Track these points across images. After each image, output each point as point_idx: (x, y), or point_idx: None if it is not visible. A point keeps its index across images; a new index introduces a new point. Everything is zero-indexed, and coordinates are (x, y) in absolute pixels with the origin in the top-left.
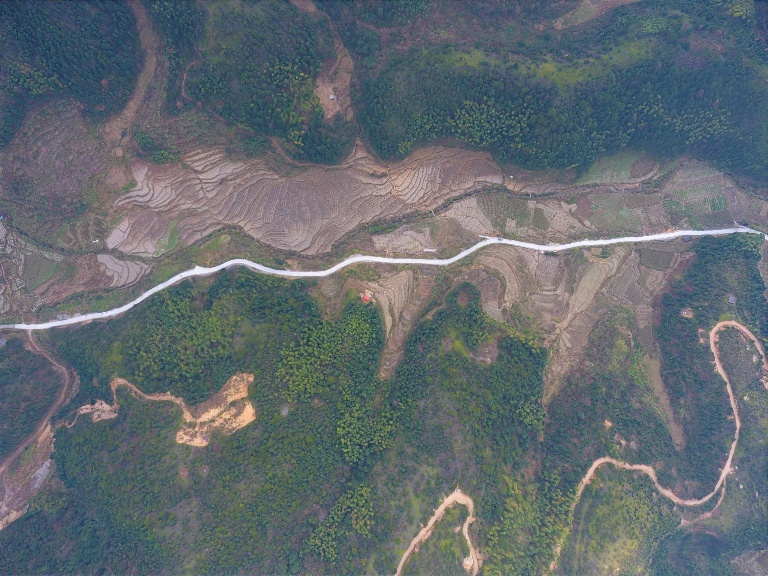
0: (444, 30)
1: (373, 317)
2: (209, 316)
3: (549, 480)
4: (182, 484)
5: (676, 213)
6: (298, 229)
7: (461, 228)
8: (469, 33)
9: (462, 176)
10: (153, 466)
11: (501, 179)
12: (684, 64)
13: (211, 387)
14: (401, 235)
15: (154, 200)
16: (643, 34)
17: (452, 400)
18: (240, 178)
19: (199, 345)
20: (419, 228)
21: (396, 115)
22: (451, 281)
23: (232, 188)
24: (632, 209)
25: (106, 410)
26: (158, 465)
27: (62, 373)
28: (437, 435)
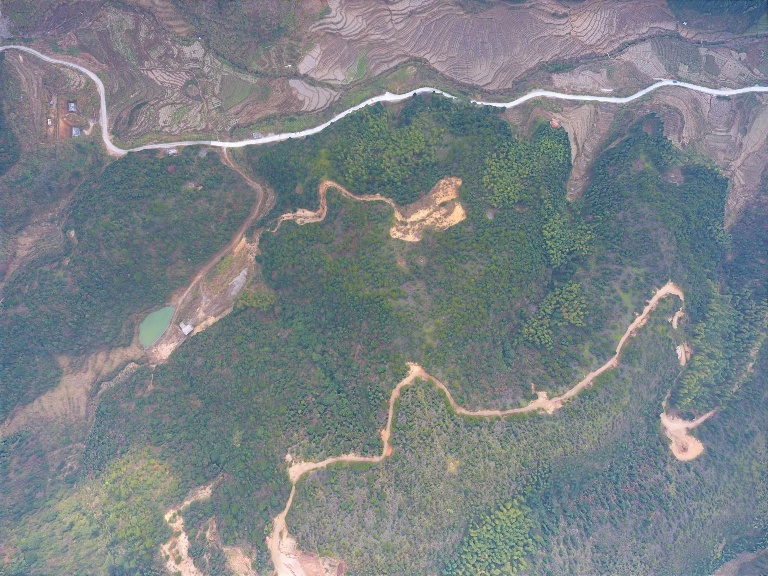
0: None
1: (566, 138)
2: (409, 131)
3: (739, 294)
4: (403, 270)
5: None
6: (481, 64)
7: (636, 70)
8: None
9: (637, 21)
10: (375, 252)
11: (674, 26)
12: None
13: (421, 188)
14: (579, 74)
15: (346, 28)
16: None
17: (653, 209)
18: (428, 12)
19: (402, 155)
20: (596, 68)
21: None
22: (633, 114)
23: (419, 21)
24: None
25: (310, 216)
26: (379, 252)
27: (256, 189)
28: (641, 239)
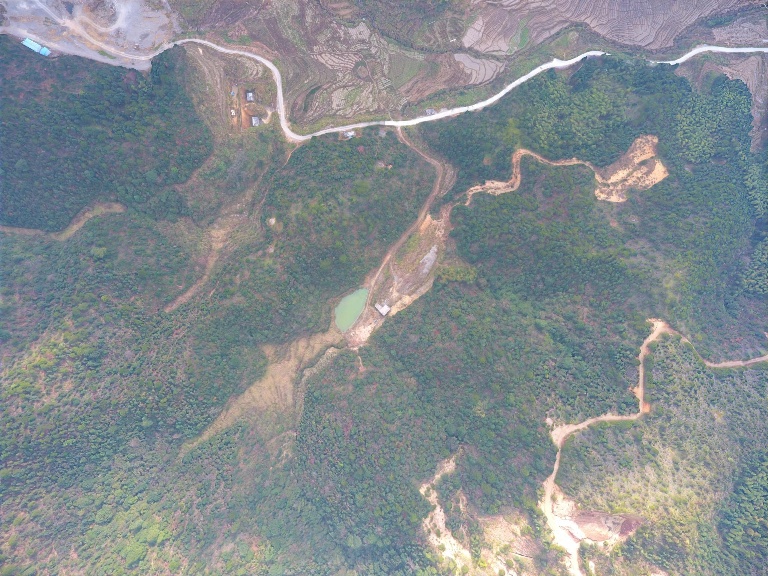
0: None
1: (746, 90)
2: (590, 94)
3: None
4: (619, 230)
5: None
6: (642, 24)
7: None
8: None
9: None
10: None
11: None
12: None
13: (619, 149)
14: (739, 27)
15: None
16: None
17: None
18: None
19: (589, 118)
20: (756, 20)
21: None
22: None
23: None
24: None
25: (501, 186)
26: (592, 215)
27: (435, 165)
28: None
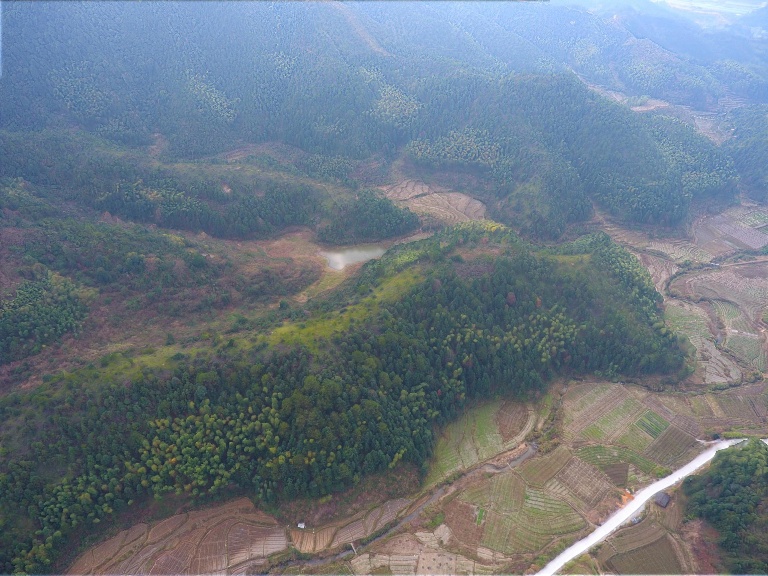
0: (119, 343)
1: None
2: None
3: None
4: None
5: (610, 464)
6: None
7: None
8: (161, 334)
9: (197, 569)
10: None
11: (283, 539)
12: (469, 276)
13: None
14: None
15: None
16: (402, 266)
17: None
18: None
19: None
20: None
21: (2, 499)
22: None
23: None
24: (542, 489)
25: None
26: None
27: None
28: None
